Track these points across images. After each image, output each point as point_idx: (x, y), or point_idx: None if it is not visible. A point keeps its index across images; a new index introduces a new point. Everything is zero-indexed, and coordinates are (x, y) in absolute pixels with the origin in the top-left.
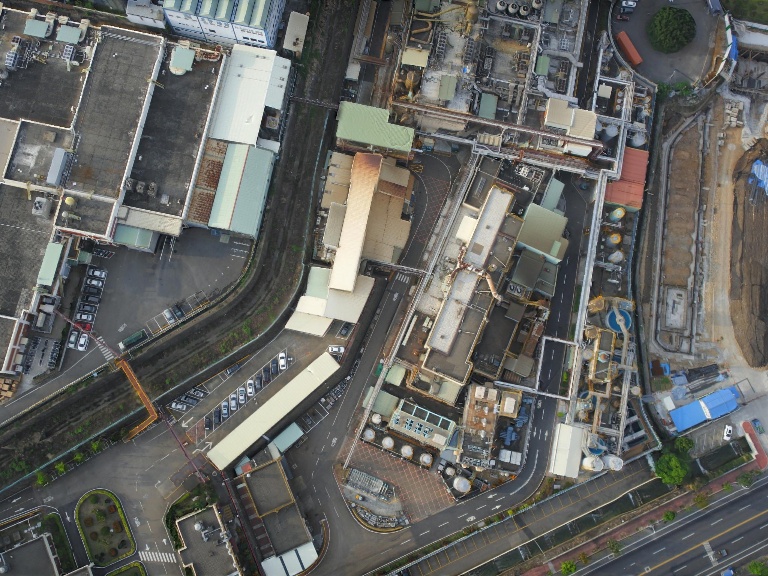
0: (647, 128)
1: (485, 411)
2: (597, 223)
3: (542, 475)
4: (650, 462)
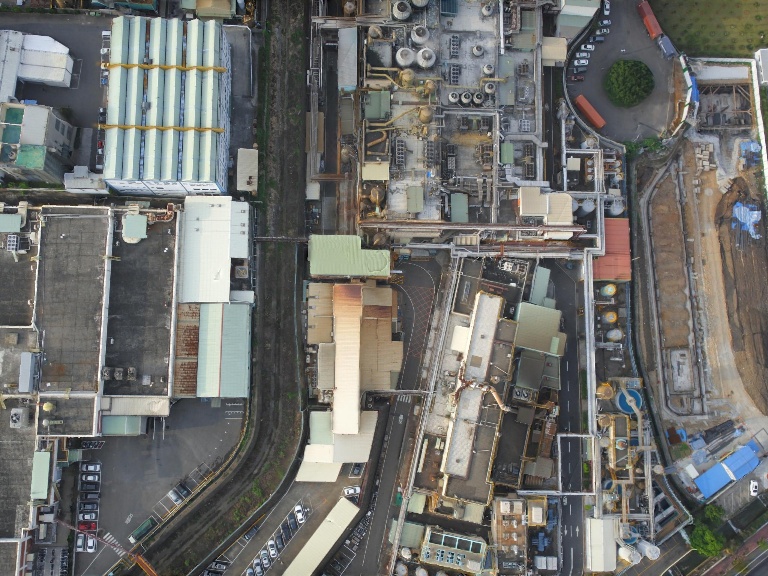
0: (622, 192)
1: (514, 525)
2: (590, 306)
3: (580, 572)
4: (684, 535)
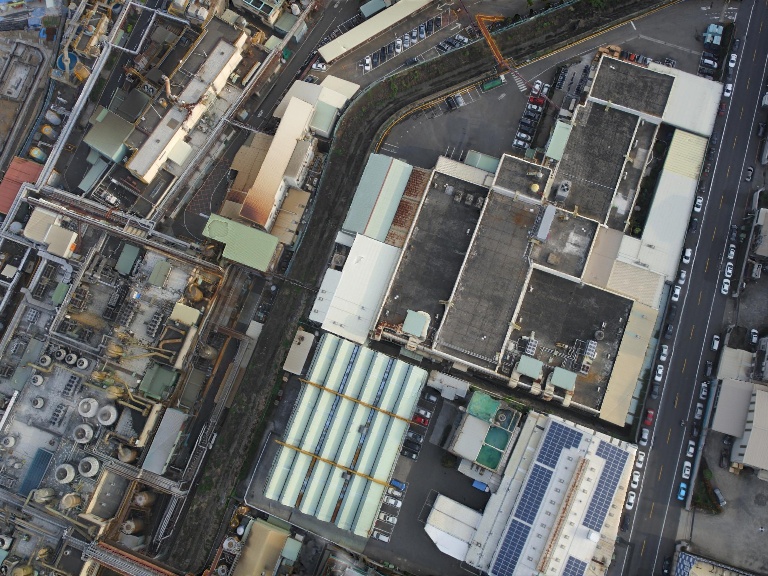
0: None
1: None
2: (59, 144)
3: None
4: None
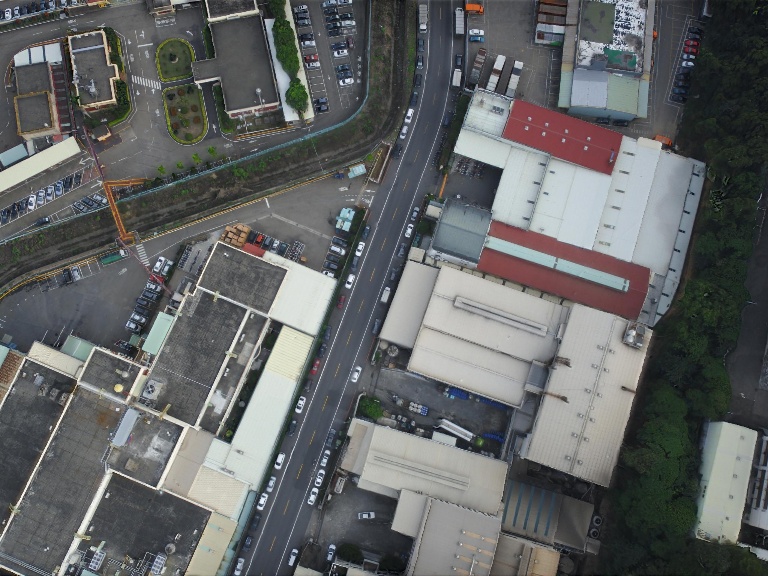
0: None
1: None
2: None
3: None
4: None
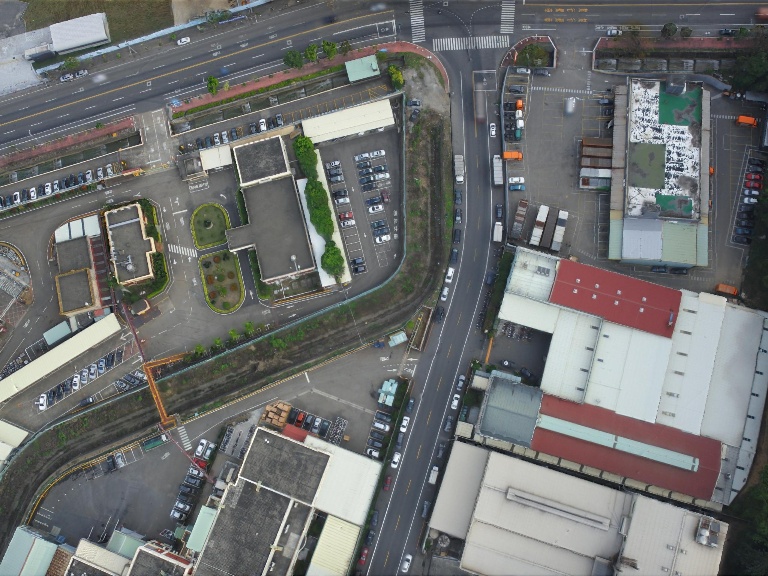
0: None
1: None
2: None
3: None
4: None
